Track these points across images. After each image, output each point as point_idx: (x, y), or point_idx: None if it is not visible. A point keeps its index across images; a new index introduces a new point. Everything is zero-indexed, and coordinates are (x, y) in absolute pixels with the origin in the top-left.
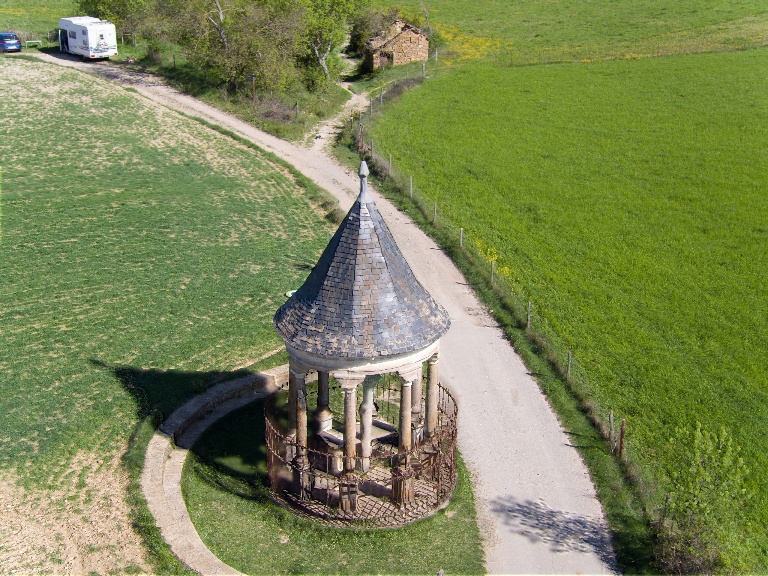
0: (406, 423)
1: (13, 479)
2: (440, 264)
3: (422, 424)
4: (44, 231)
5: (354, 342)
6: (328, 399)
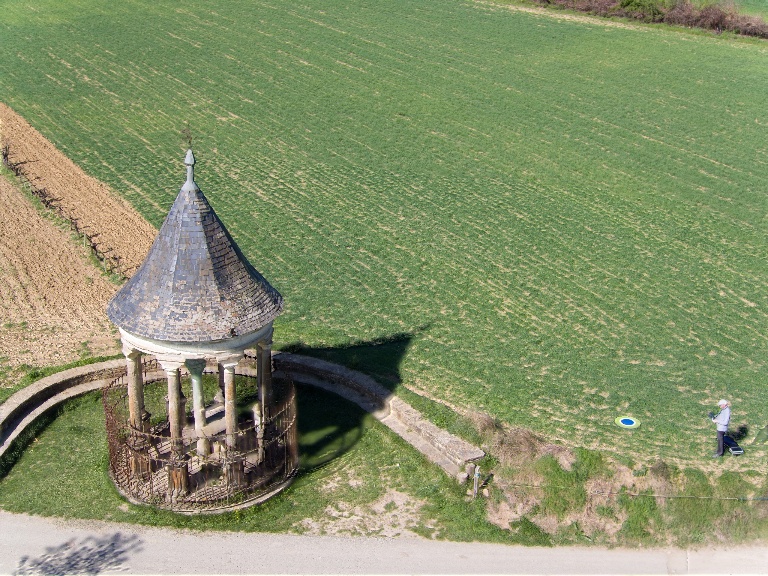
0: None
1: None
2: None
3: None
4: (764, 288)
5: None
6: (261, 395)
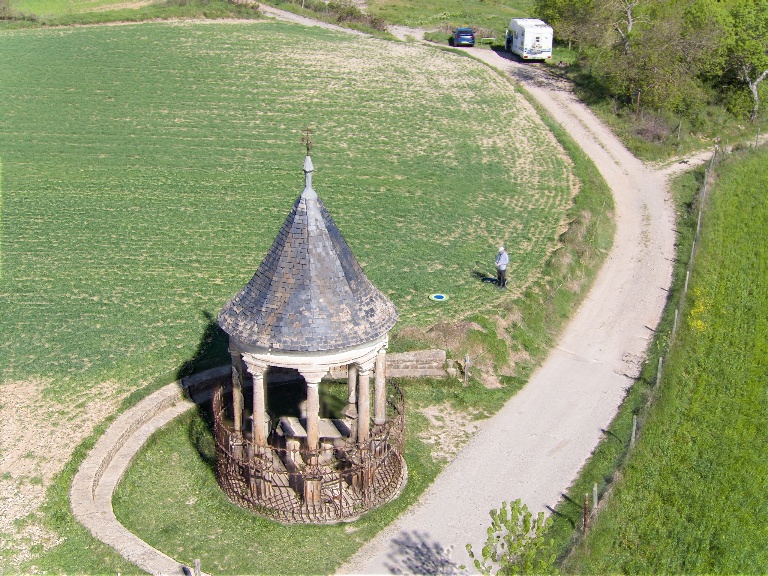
0: (310, 424)
1: (44, 386)
2: (651, 305)
3: (382, 437)
4: None
5: (255, 329)
6: None
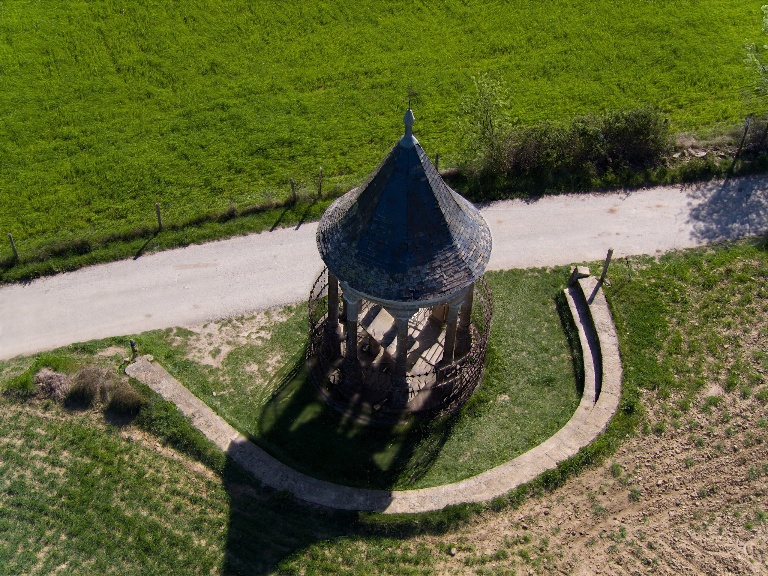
0: None
1: None
2: None
3: None
4: None
5: None
6: None
